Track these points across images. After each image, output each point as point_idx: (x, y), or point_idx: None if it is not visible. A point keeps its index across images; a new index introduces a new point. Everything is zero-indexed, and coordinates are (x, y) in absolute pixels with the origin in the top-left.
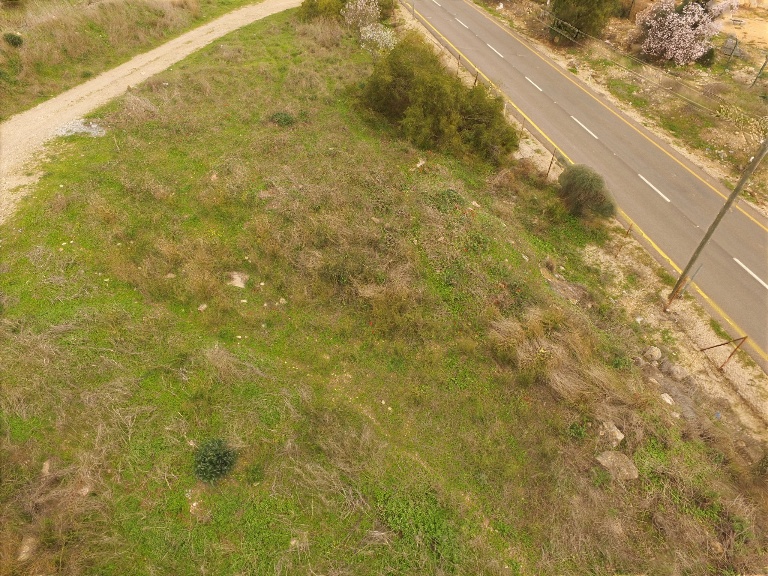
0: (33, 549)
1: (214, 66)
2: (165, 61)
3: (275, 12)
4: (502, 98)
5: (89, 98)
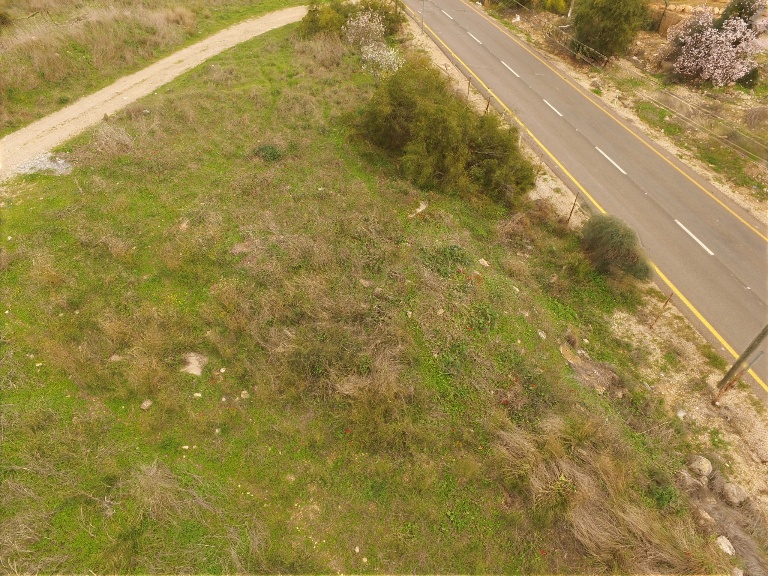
0: None
1: (202, 90)
2: (151, 84)
3: (276, 27)
4: (517, 129)
5: (62, 128)
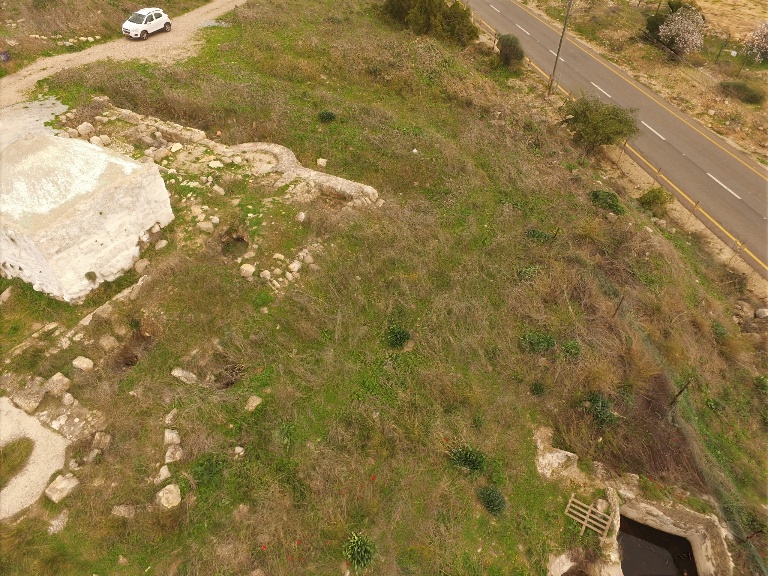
0: None
1: None
2: None
3: None
4: (469, 9)
5: (212, 12)
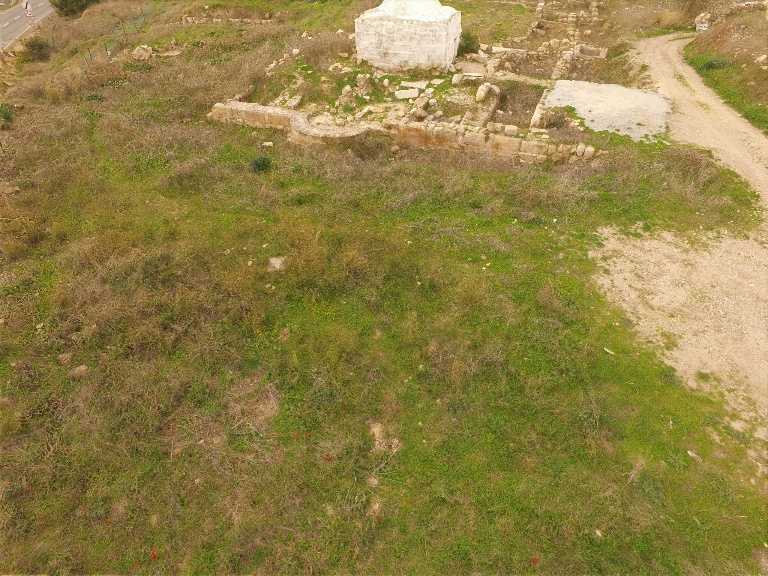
0: None
1: None
2: None
3: None
4: None
5: None
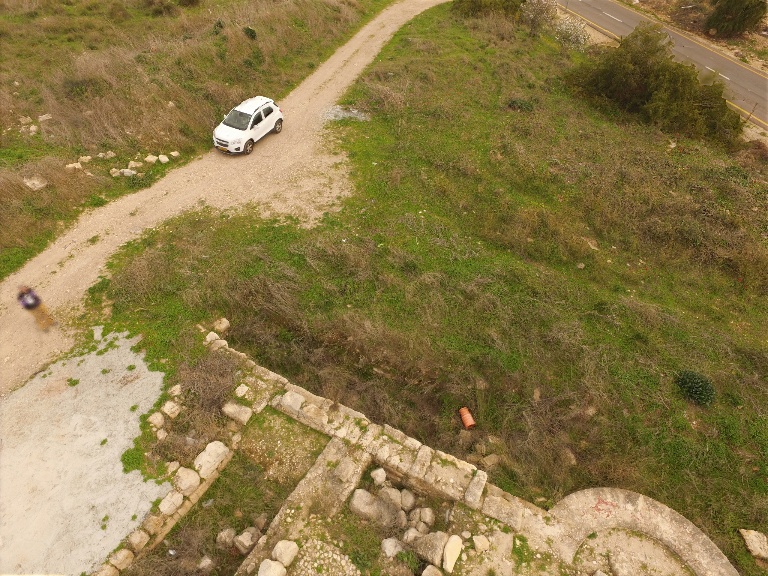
0: (576, 456)
1: (419, 57)
2: (366, 53)
3: (427, 8)
4: (722, 85)
5: (327, 87)
